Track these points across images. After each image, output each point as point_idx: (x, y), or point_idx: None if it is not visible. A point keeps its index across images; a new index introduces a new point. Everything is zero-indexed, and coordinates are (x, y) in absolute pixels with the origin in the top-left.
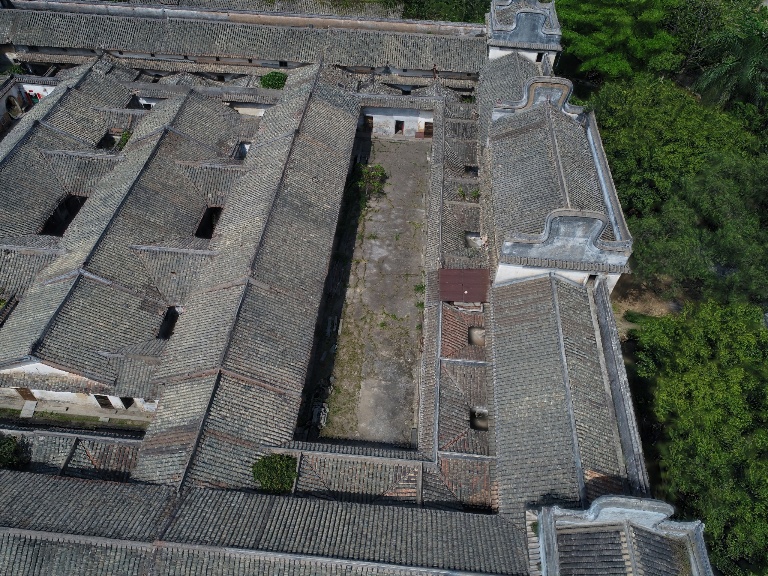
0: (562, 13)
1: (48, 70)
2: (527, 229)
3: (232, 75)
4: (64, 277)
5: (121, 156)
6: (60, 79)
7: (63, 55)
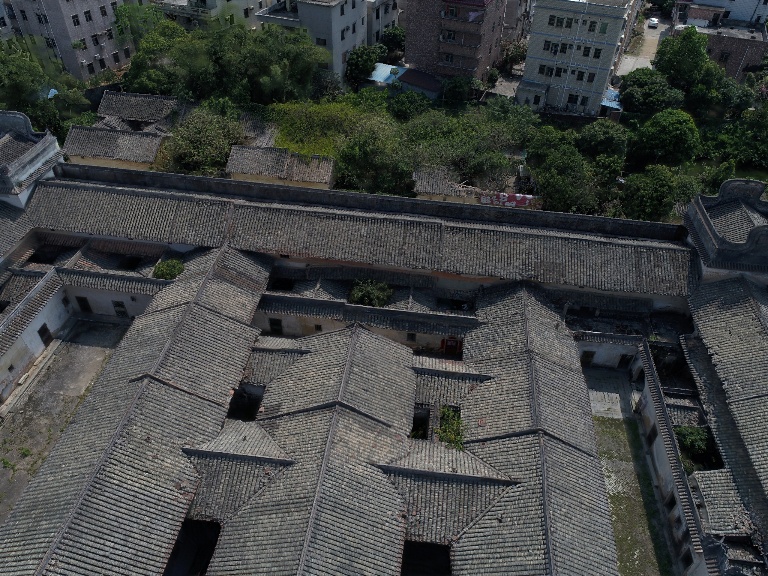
0: None
1: None
2: None
3: None
4: None
5: None
6: None
7: None
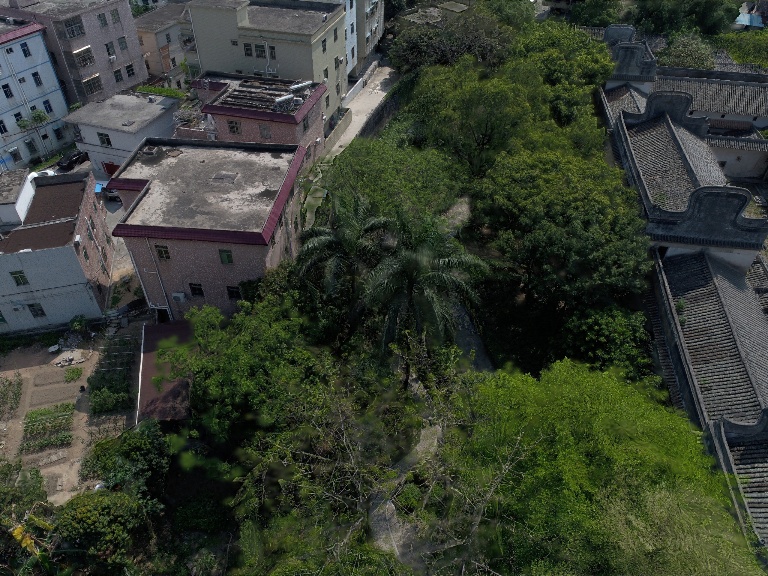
0: (728, 499)
1: None
2: (692, 138)
3: None
4: None
5: None
6: None
7: None
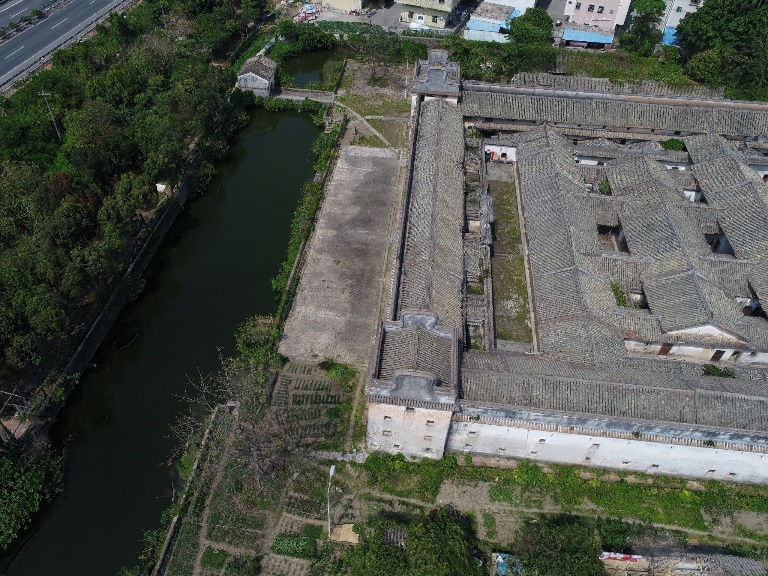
0: None
1: (500, 135)
2: None
3: (633, 140)
4: (679, 275)
5: (629, 198)
6: (517, 142)
7: (510, 124)
